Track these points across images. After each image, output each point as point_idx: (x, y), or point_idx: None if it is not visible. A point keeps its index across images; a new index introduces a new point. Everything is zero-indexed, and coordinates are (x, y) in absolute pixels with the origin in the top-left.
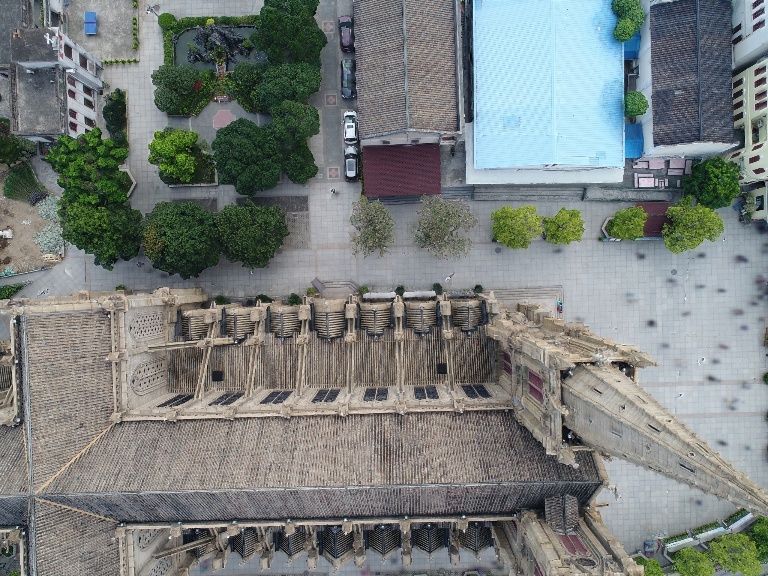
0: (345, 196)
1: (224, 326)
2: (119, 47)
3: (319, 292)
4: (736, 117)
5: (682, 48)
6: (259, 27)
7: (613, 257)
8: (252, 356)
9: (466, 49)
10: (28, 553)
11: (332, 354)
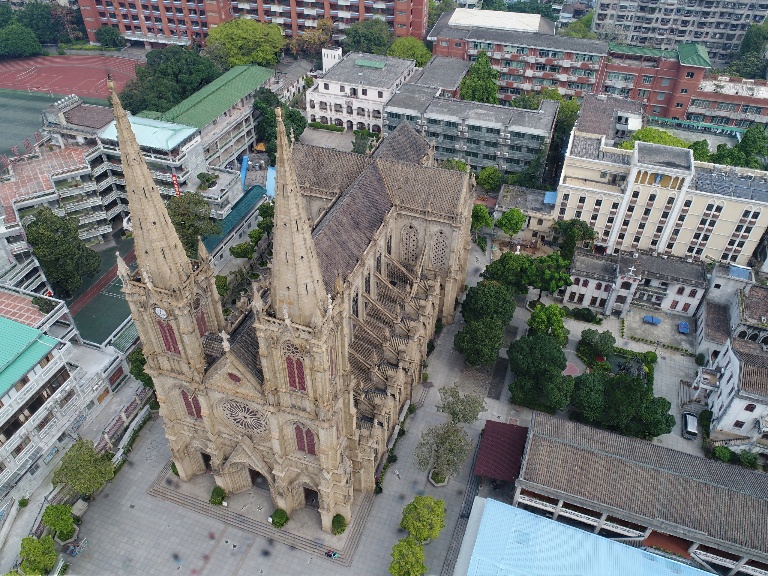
0: None
1: None
2: (634, 331)
3: (423, 383)
4: None
5: None
6: None
7: None
8: None
9: None
10: None
11: None
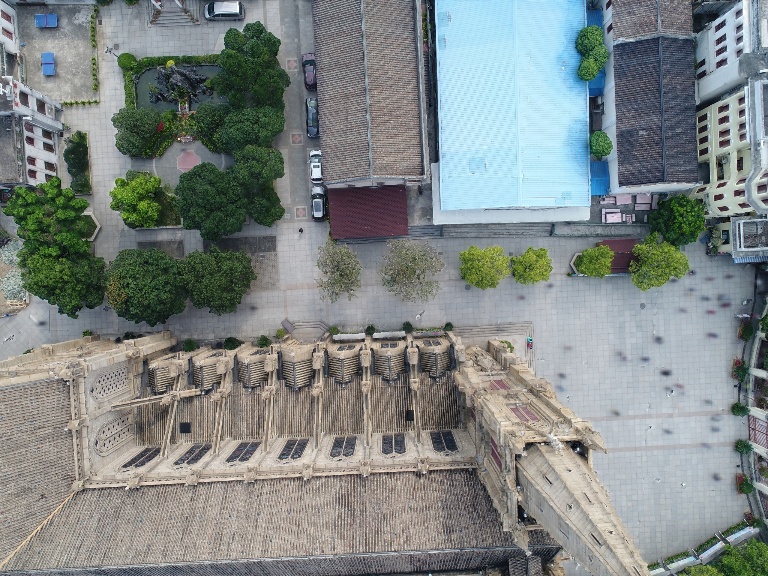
0: (313, 236)
1: (191, 375)
2: (79, 88)
3: (289, 333)
4: (701, 152)
5: (645, 88)
6: (221, 66)
7: (582, 292)
8: (218, 410)
9: (432, 86)
10: None
11: (300, 403)
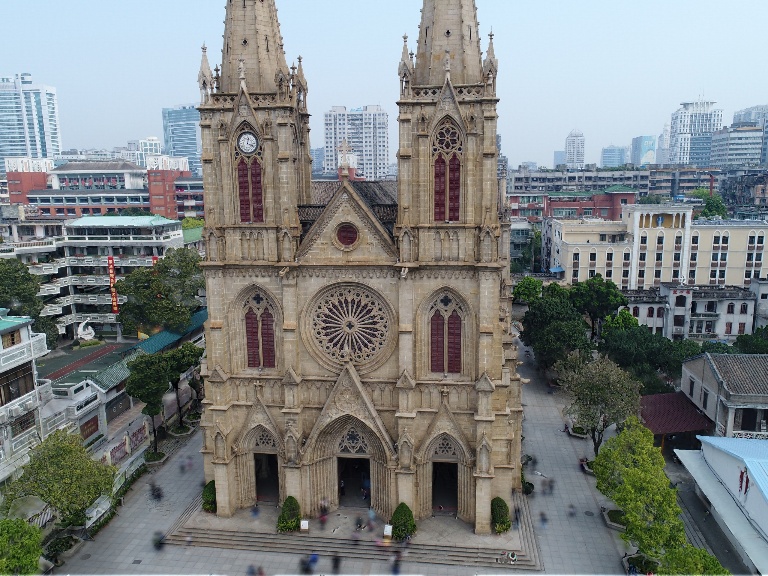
0: None
1: None
2: None
3: None
4: None
5: None
6: None
7: None
8: None
9: None
10: None
11: None
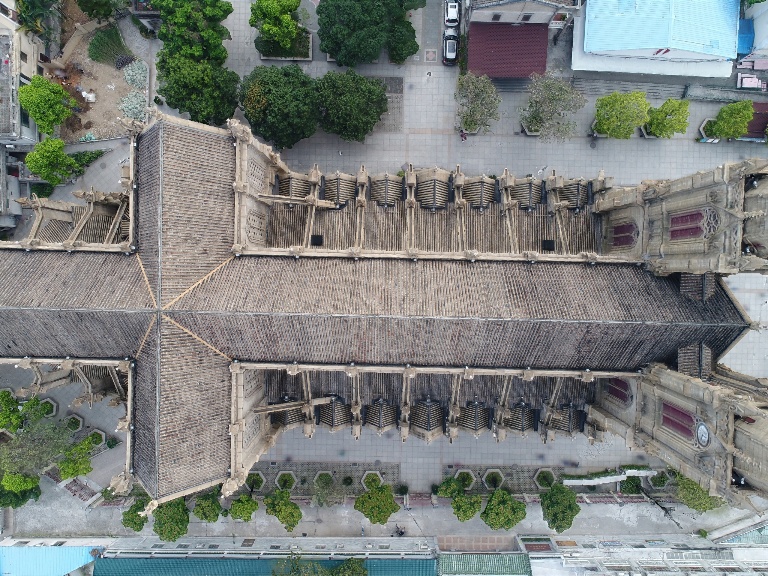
0: (441, 80)
1: (322, 193)
2: None
3: None
4: None
5: None
6: None
7: (708, 159)
8: (359, 216)
9: None
10: (135, 387)
11: (435, 225)
